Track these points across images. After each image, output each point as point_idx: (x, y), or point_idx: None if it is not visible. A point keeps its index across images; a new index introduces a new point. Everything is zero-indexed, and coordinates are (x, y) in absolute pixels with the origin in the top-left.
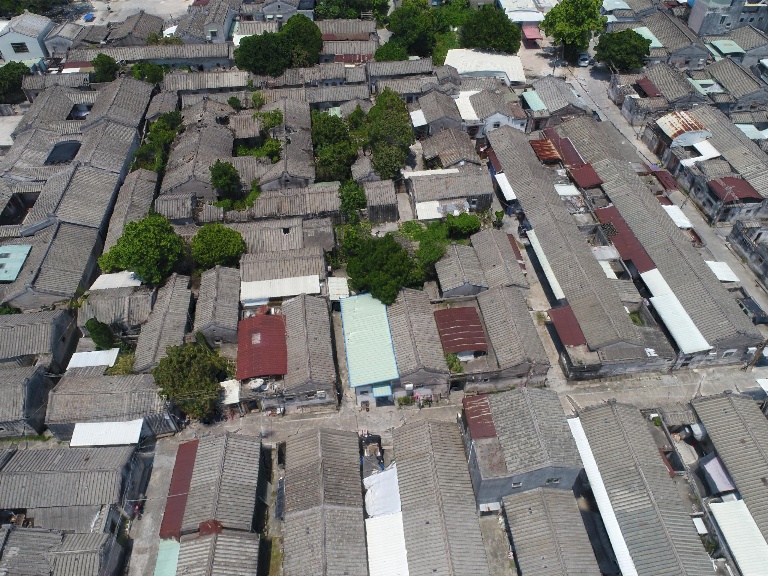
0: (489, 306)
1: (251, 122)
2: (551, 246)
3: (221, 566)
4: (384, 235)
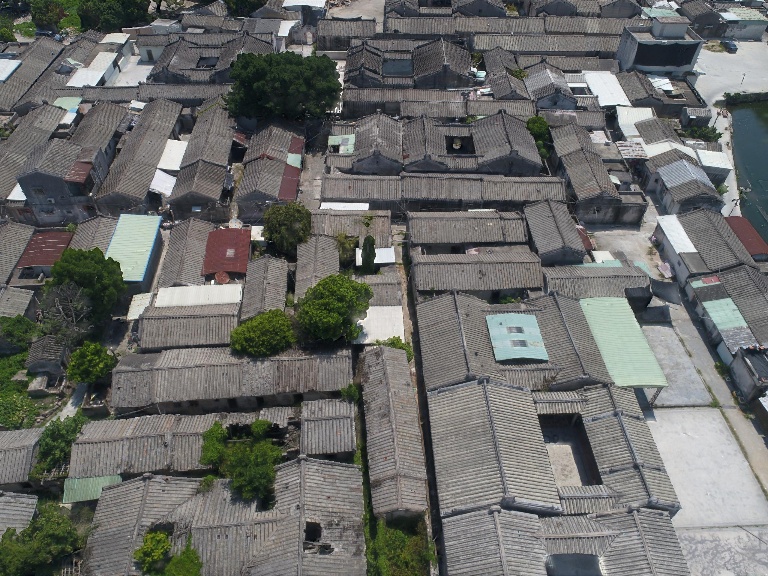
0: (1, 271)
1: None
2: None
3: (261, 147)
4: (48, 423)
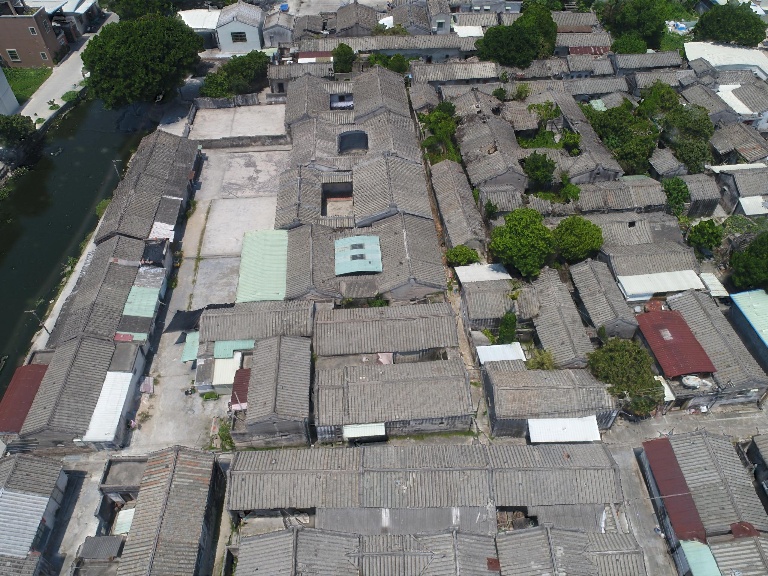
0: None
1: (527, 114)
2: None
3: None
4: None
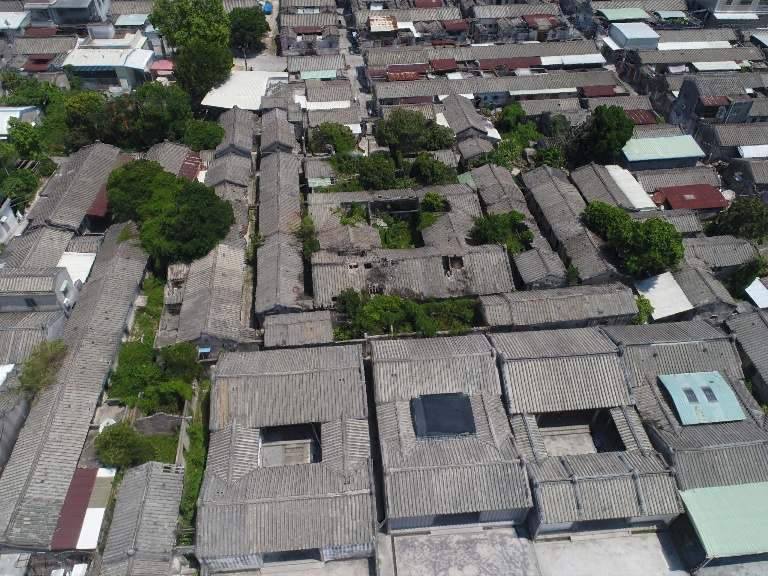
0: None
1: (359, 230)
2: (531, 84)
3: None
4: None
